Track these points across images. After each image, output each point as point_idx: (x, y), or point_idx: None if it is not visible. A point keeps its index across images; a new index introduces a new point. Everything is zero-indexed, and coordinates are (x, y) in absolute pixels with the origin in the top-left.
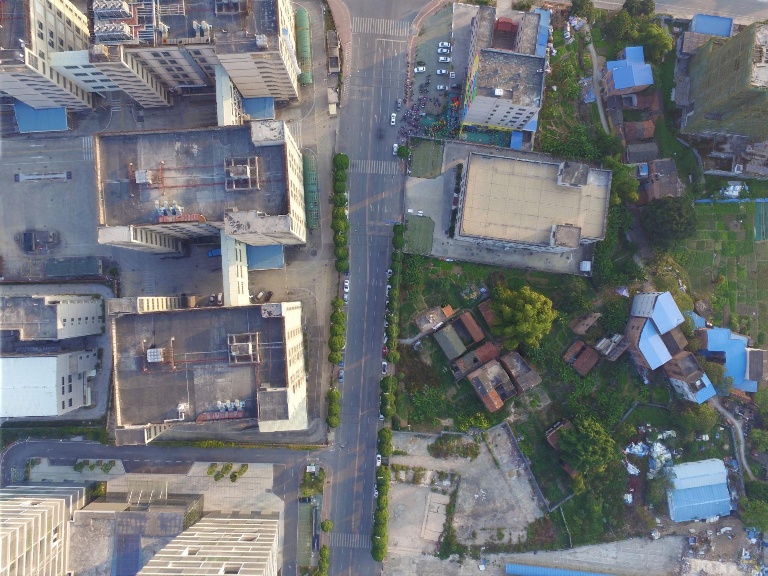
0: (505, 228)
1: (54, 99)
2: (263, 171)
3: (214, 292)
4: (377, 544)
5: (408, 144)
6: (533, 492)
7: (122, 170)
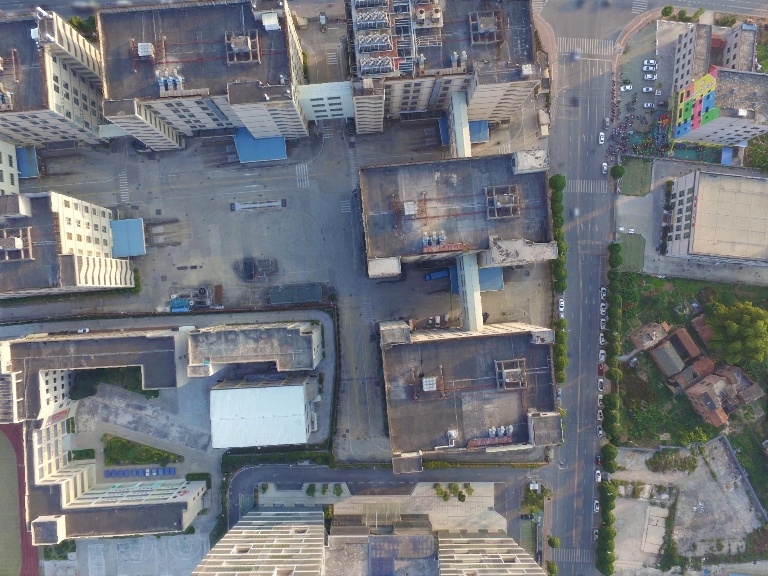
0: (733, 245)
1: (282, 129)
2: (522, 199)
3: (431, 315)
4: (609, 559)
5: (618, 163)
6: (750, 503)
7: (384, 202)
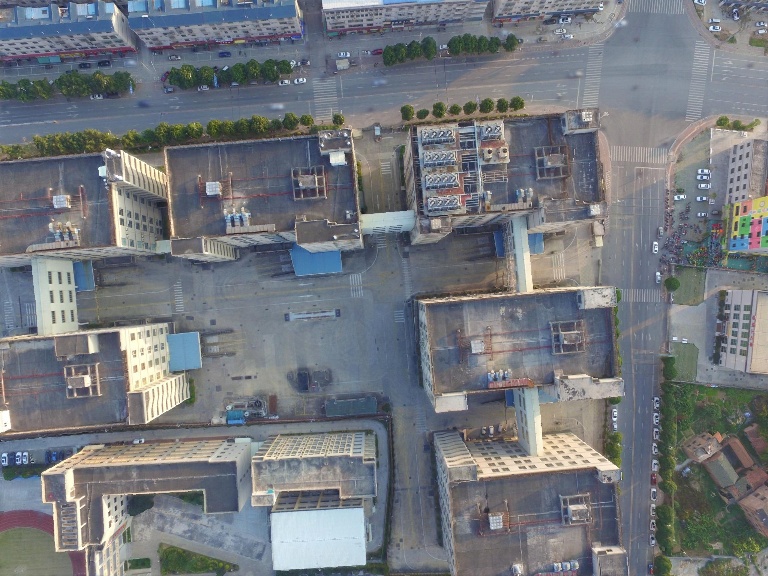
0: None
1: None
2: (587, 333)
3: (484, 424)
4: None
5: (671, 272)
6: None
7: (450, 337)
